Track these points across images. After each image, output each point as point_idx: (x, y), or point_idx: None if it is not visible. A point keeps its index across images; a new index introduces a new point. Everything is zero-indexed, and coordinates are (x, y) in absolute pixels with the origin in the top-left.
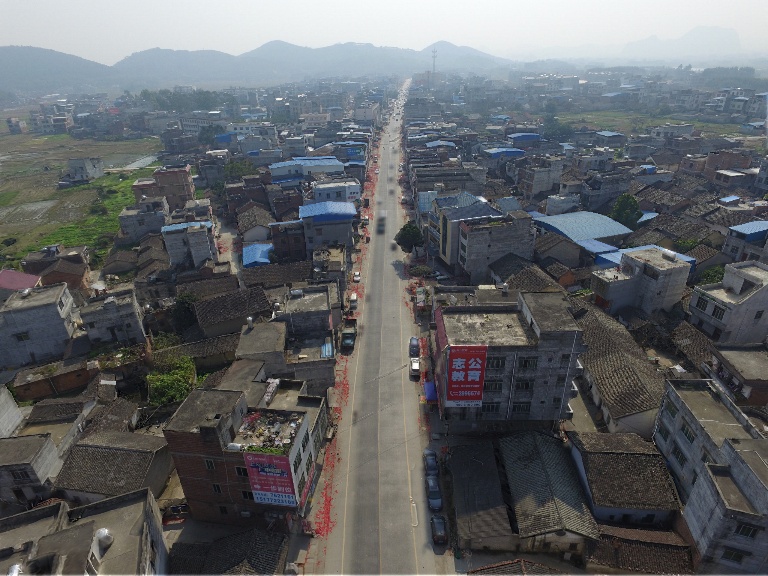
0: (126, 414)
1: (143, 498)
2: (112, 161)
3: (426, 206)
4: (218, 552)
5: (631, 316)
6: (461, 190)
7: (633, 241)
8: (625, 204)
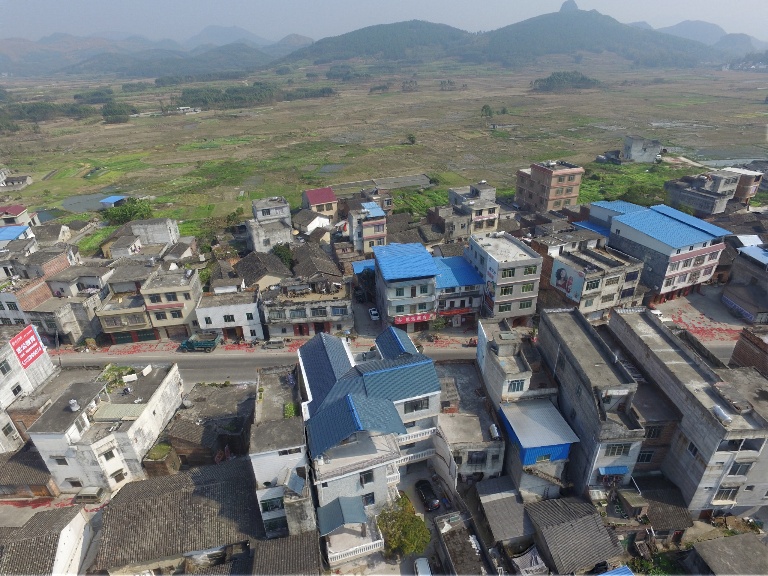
0: None
1: None
2: (719, 152)
3: (480, 353)
4: None
5: None
6: (575, 394)
7: None
8: None
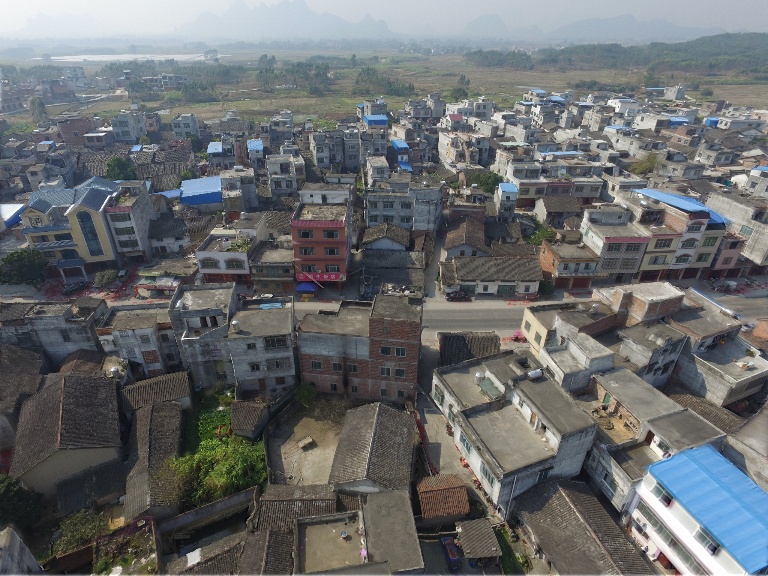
0: (288, 488)
1: (441, 375)
2: None
3: None
4: (453, 361)
5: (261, 211)
6: None
7: (162, 187)
8: (122, 165)
